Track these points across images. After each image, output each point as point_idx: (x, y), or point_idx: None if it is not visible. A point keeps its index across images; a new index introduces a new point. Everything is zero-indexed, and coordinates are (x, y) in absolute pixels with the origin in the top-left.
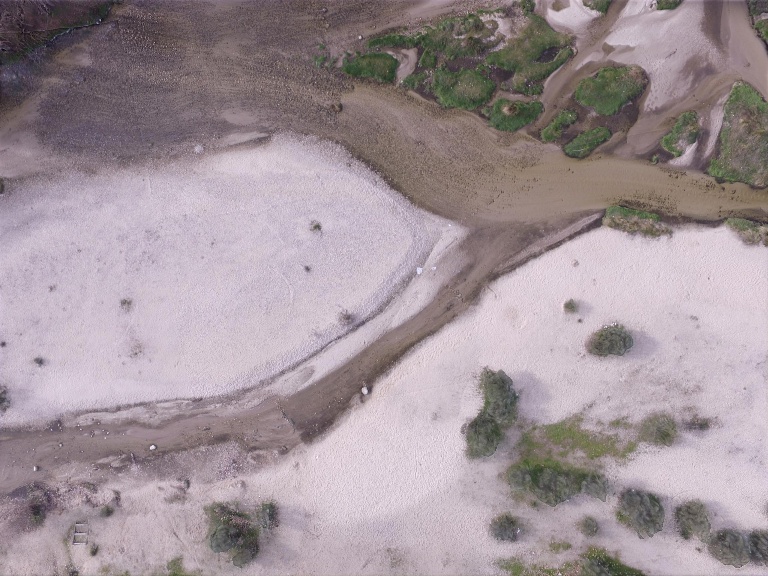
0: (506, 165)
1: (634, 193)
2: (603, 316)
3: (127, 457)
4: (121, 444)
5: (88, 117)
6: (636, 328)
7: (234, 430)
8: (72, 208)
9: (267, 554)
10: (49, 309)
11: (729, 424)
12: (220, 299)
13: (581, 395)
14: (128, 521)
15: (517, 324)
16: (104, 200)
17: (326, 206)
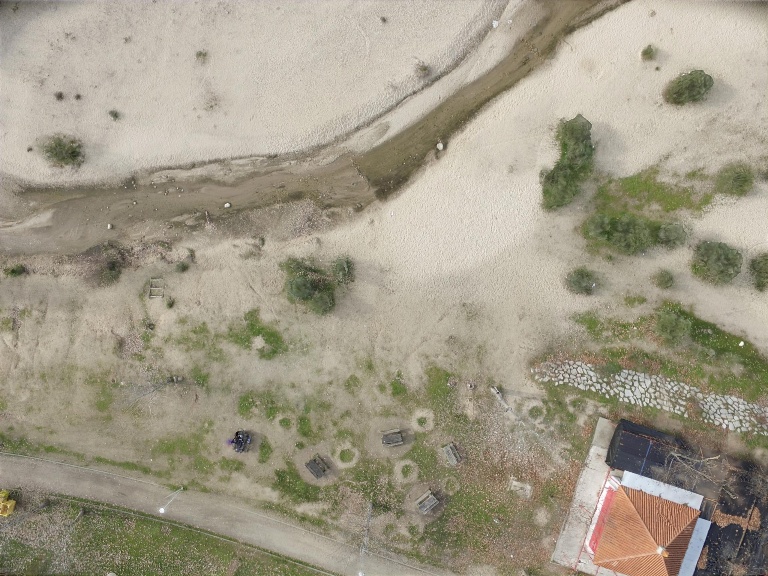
0: None
1: None
2: (681, 64)
3: (201, 215)
4: (195, 202)
5: None
6: (714, 76)
7: (309, 188)
8: None
9: (343, 307)
10: (124, 61)
11: None
12: (296, 51)
13: (657, 146)
14: (204, 276)
15: (594, 75)
16: None
17: None
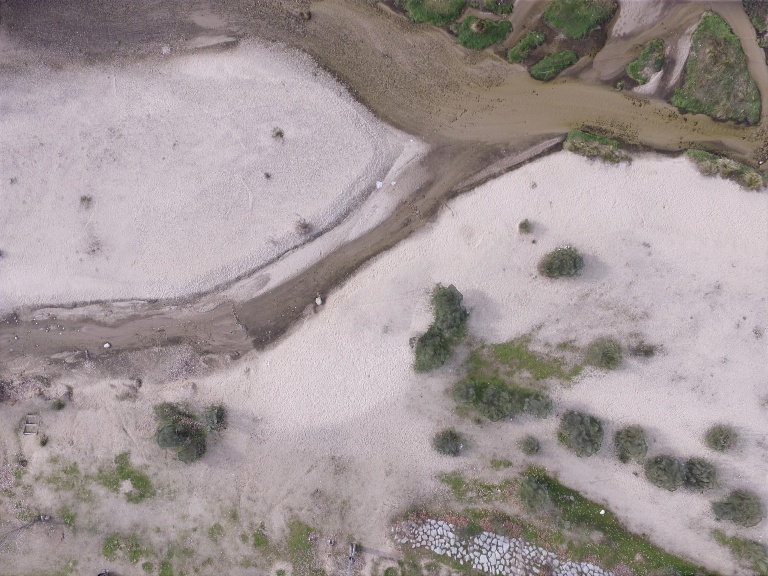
0: (471, 83)
1: (597, 119)
2: (557, 238)
3: (81, 353)
4: (76, 340)
5: (56, 11)
6: (589, 252)
7: (188, 333)
8: (36, 102)
9: (214, 454)
10: (9, 201)
11: (674, 353)
12: (179, 201)
13: (531, 316)
14: (79, 415)
15: (472, 242)
16: (68, 95)
17: (289, 114)
